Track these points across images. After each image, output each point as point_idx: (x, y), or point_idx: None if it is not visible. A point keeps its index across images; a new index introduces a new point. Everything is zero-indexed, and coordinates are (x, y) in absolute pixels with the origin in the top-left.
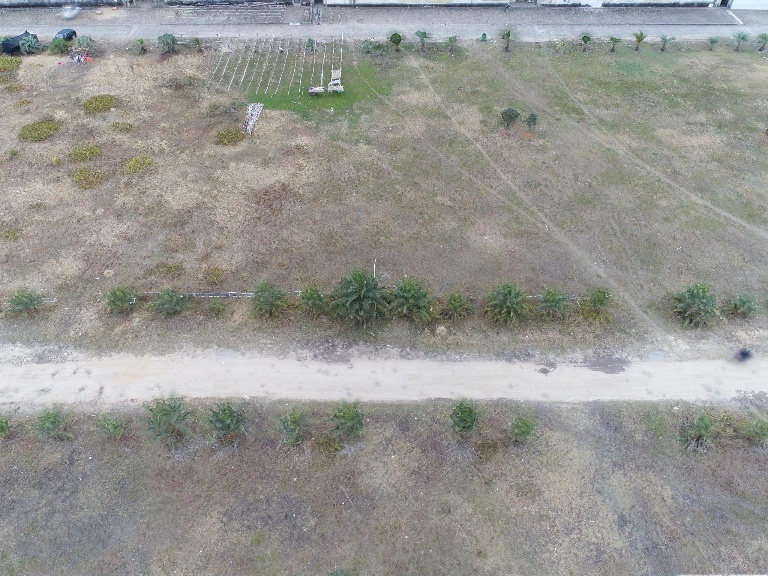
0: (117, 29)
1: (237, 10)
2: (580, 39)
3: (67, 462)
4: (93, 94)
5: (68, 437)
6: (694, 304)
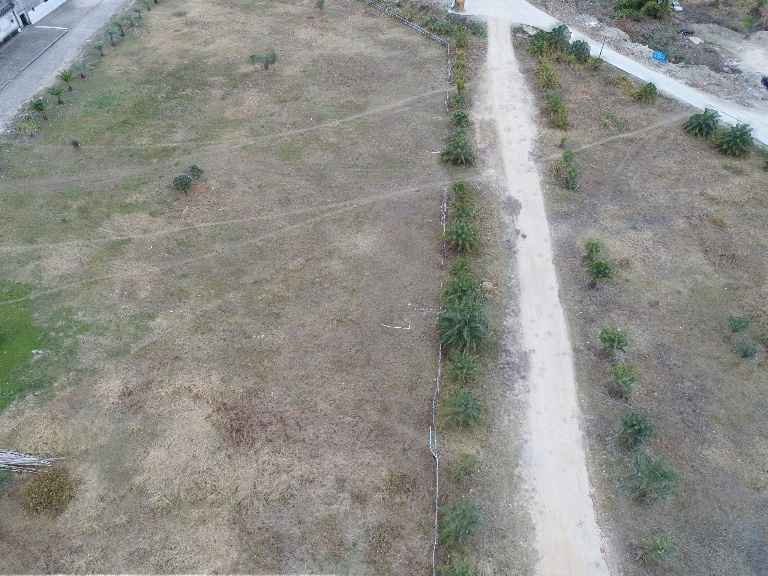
0: None
1: None
2: (15, 115)
3: None
4: None
5: None
6: (467, 150)
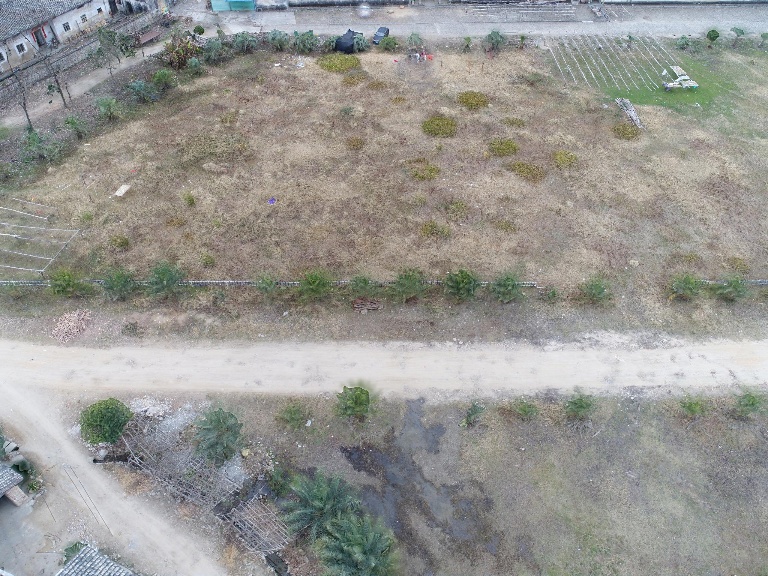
0: (421, 27)
1: (528, 8)
2: None
3: (765, 441)
4: (457, 91)
5: (747, 418)
6: None
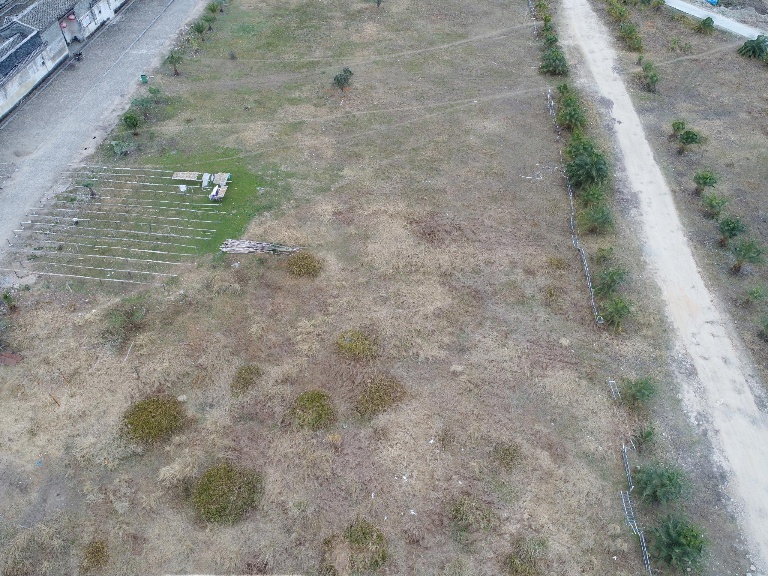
0: None
1: None
2: (177, 37)
3: None
4: (108, 438)
5: None
6: (564, 62)
